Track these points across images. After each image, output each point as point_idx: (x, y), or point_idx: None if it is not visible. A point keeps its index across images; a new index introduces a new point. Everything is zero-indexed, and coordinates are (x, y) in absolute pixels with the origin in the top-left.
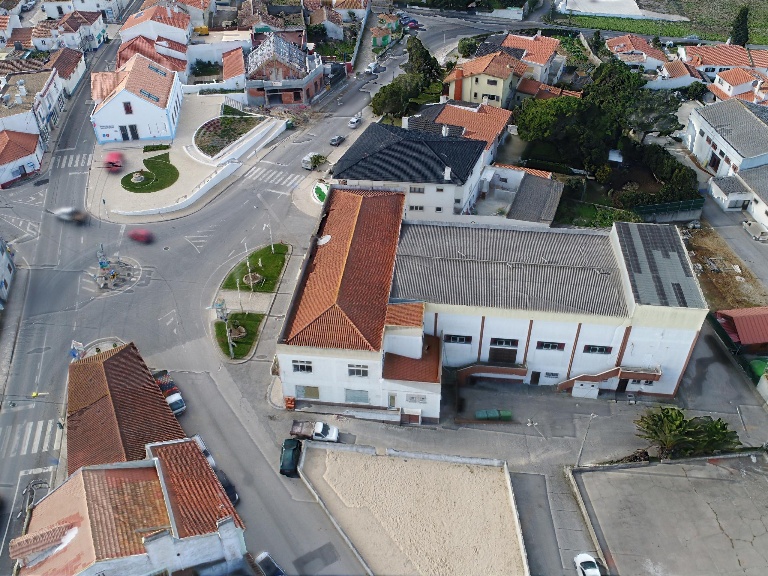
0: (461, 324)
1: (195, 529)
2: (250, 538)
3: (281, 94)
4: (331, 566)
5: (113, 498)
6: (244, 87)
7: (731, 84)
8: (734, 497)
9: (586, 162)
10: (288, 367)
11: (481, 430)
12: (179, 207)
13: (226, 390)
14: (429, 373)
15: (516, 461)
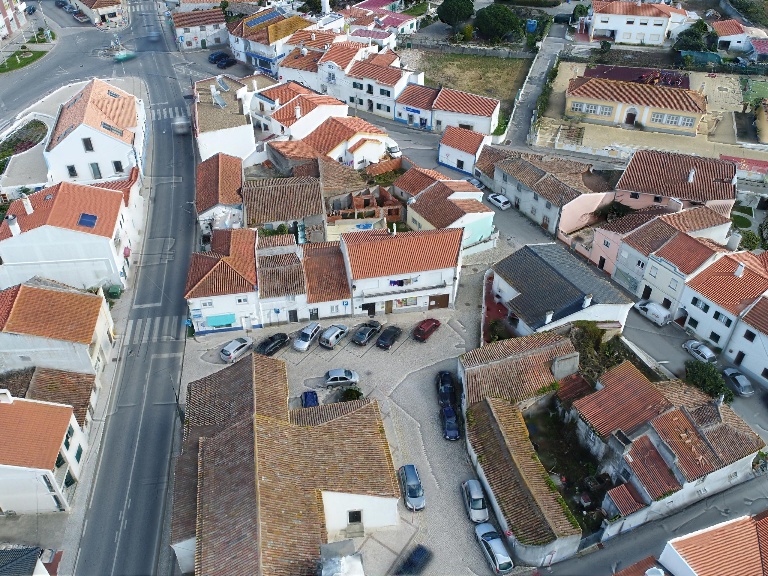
0: None
1: None
2: (54, 1)
3: None
4: None
5: None
6: None
7: None
8: None
9: None
10: None
11: None
12: None
13: (55, 24)
14: None
15: None
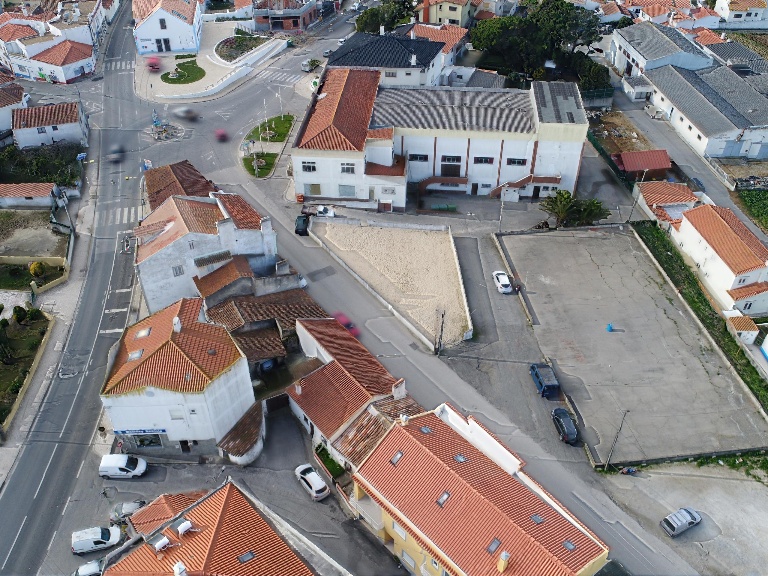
0: (420, 145)
1: (246, 227)
2: None
3: (282, 21)
4: (332, 276)
5: (193, 211)
6: (252, 16)
7: (651, 16)
8: (604, 246)
9: (525, 66)
10: (299, 168)
11: (435, 216)
12: (208, 93)
13: (254, 193)
14: (397, 174)
15: (458, 231)
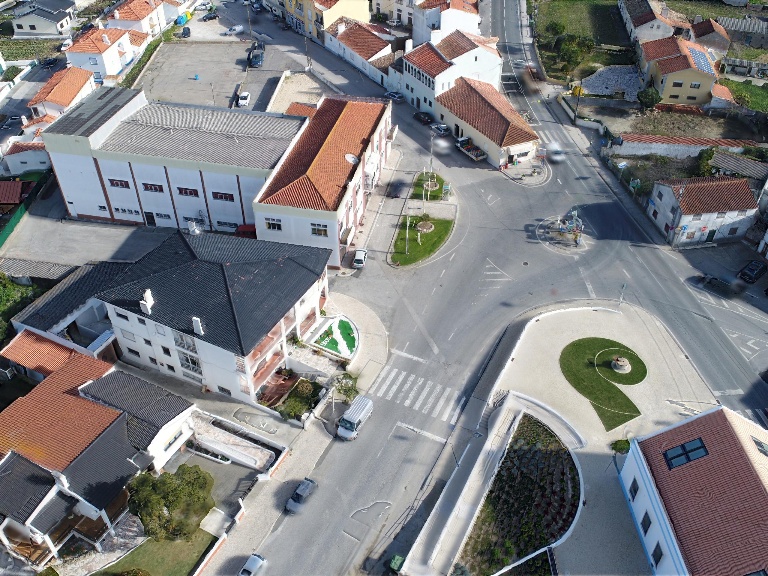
0: None
1: None
2: None
3: None
4: None
5: None
6: None
7: None
8: None
9: None
10: None
11: None
12: None
13: None
14: None
15: None
